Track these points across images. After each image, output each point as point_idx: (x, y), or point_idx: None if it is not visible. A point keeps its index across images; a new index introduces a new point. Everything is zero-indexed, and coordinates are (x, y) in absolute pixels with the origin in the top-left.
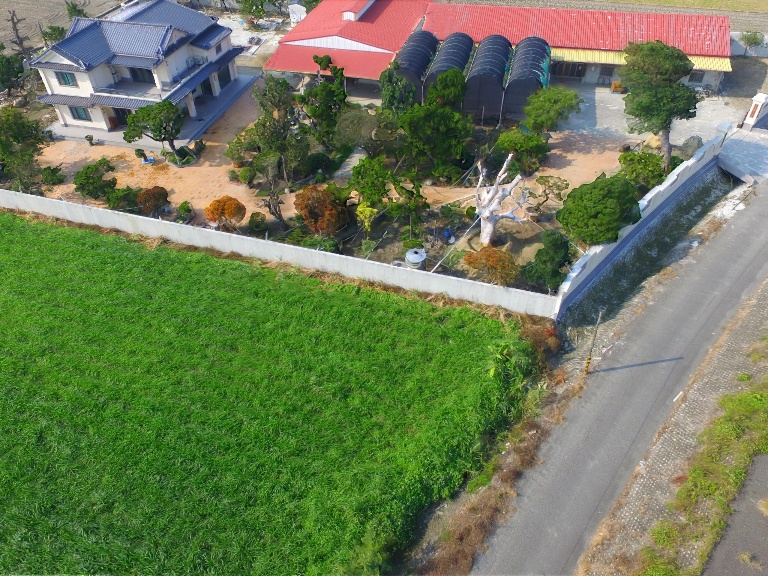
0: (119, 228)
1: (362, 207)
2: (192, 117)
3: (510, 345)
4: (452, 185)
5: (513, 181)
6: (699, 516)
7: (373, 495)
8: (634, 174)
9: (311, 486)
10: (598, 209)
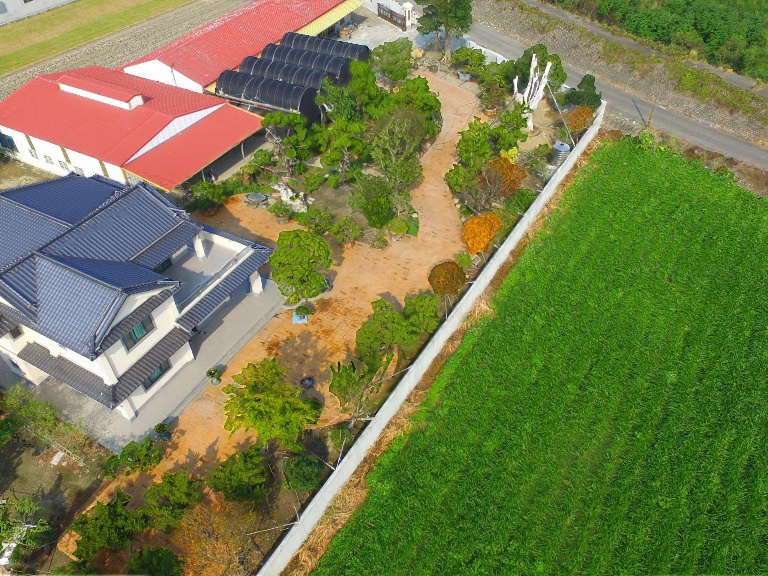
0: (448, 337)
1: (507, 154)
2: None
3: None
4: None
5: (548, 68)
6: (762, 106)
7: (766, 201)
8: None
9: (764, 226)
10: None
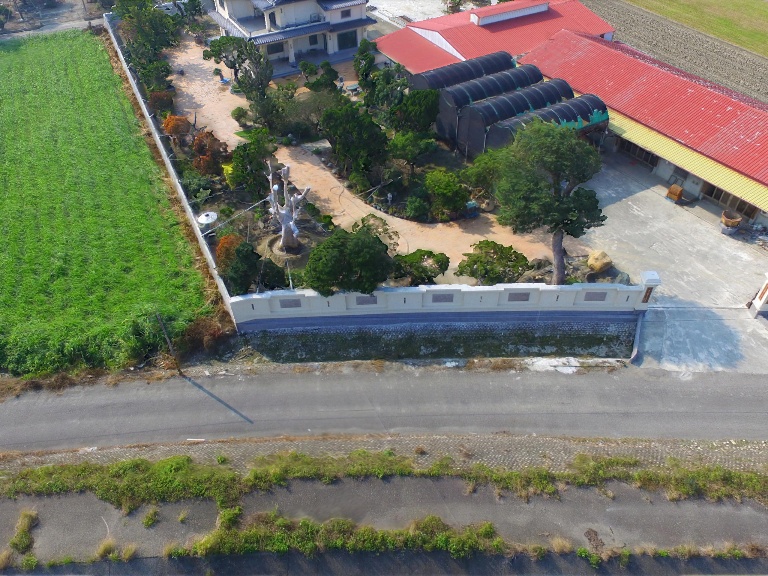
0: None
1: (230, 165)
2: (289, 62)
3: (151, 311)
4: (357, 195)
5: None
6: None
7: None
8: (477, 265)
9: None
10: (322, 254)
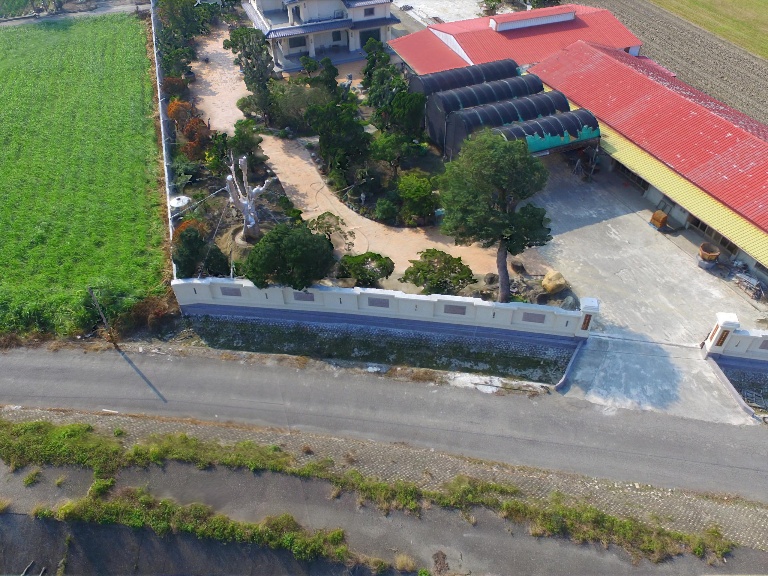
0: None
1: None
2: (309, 56)
3: (102, 285)
4: (334, 192)
5: None
6: None
7: None
8: None
9: None
10: None
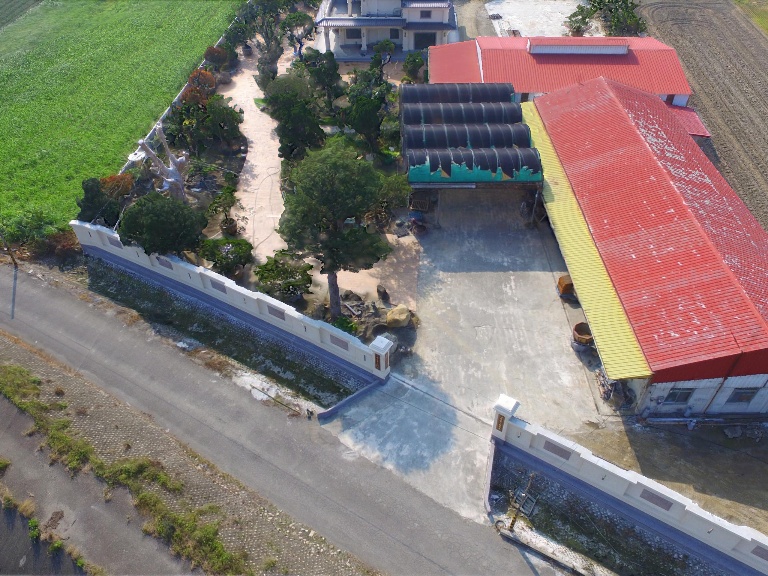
0: None
1: None
2: (361, 49)
3: None
4: None
5: None
6: None
7: None
8: None
9: None
10: None
